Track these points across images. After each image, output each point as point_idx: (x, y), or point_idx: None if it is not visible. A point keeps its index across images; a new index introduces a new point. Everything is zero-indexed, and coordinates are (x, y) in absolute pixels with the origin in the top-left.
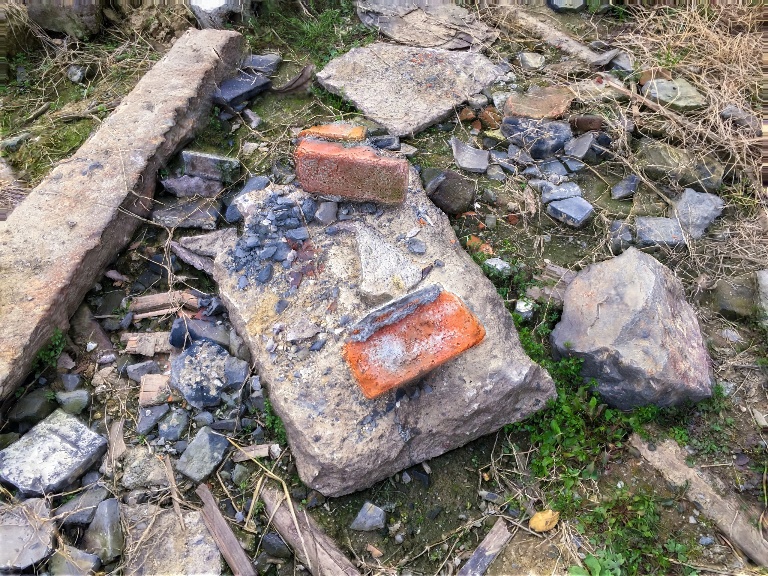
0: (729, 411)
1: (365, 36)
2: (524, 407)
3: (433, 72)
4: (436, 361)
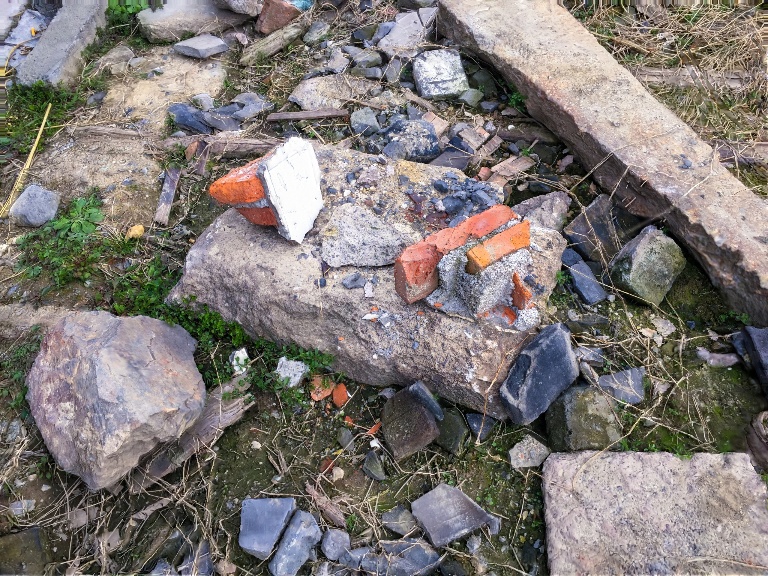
0: (6, 407)
1: None
2: None
3: None
4: None
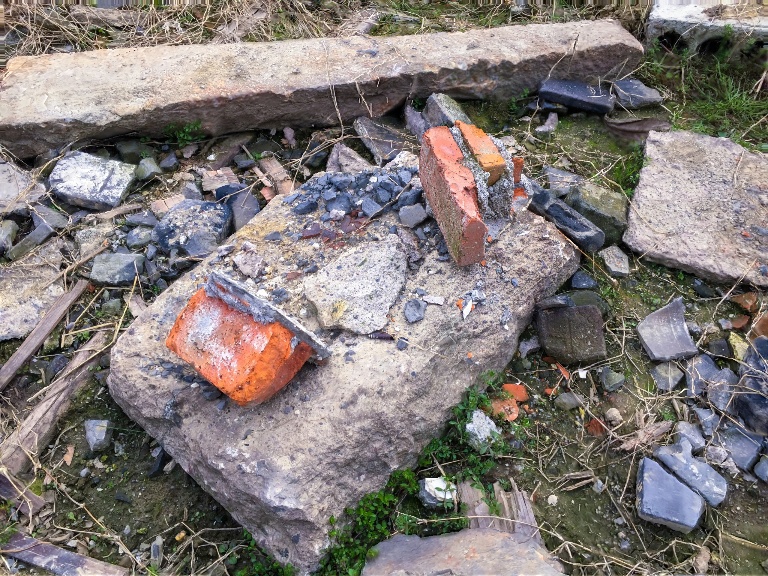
0: None
1: None
2: (270, 538)
3: None
4: (201, 370)
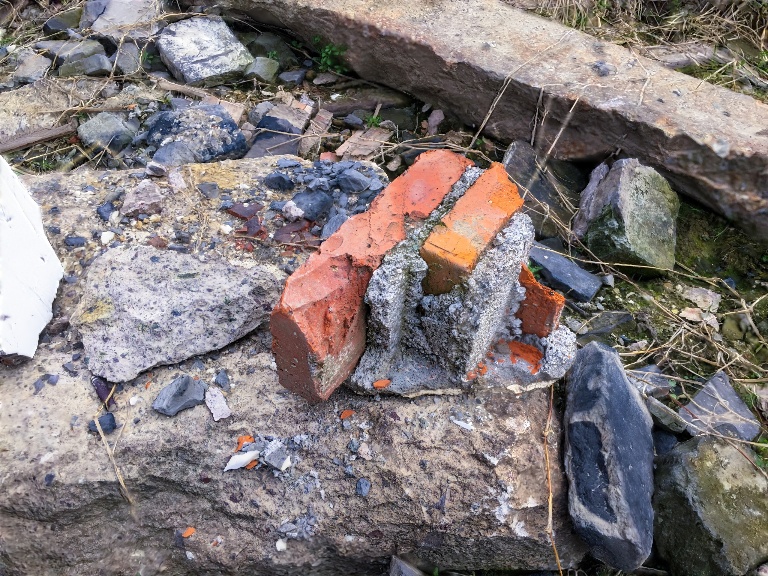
0: None
1: None
2: None
3: None
4: None
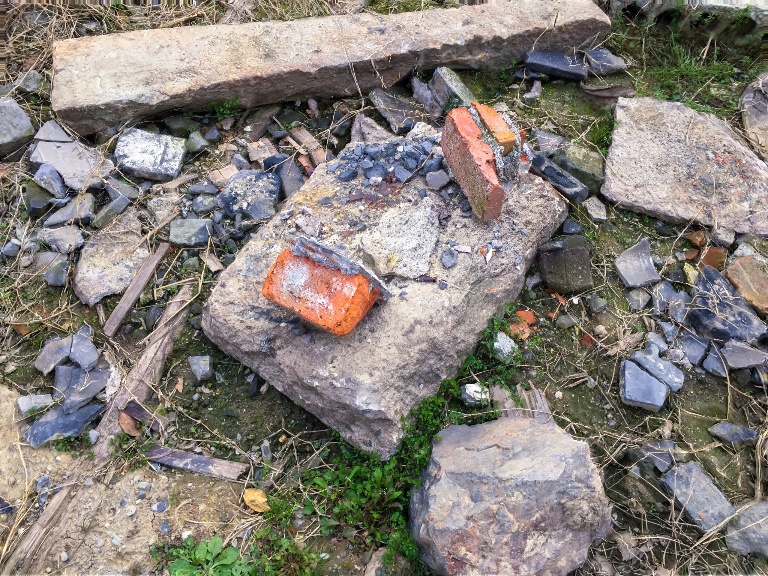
0: None
1: (723, 107)
2: (356, 434)
3: (719, 178)
4: (301, 313)
